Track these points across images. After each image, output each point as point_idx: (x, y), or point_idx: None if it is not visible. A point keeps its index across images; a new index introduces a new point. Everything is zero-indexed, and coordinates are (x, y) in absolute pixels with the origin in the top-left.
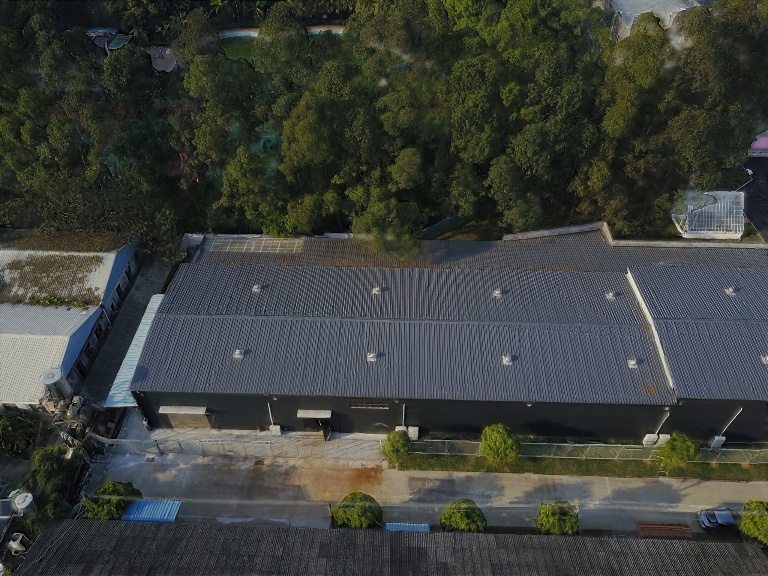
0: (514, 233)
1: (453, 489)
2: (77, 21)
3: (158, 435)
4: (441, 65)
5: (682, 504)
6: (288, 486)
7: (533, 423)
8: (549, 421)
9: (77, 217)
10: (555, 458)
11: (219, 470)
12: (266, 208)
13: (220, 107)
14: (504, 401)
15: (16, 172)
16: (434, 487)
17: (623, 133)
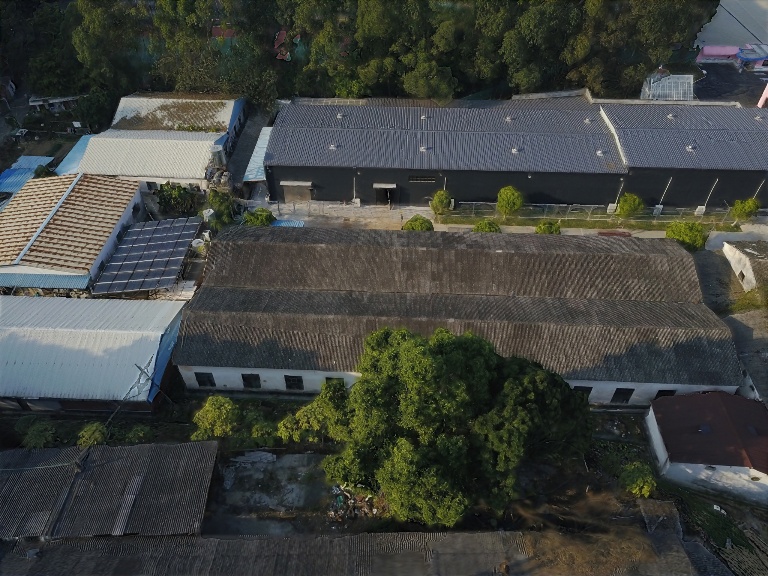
0: (520, 94)
1: None
2: None
3: (276, 206)
4: None
5: None
6: None
7: (532, 195)
8: (543, 193)
9: None
10: (547, 219)
11: (320, 223)
12: (343, 68)
13: None
14: (513, 171)
15: (166, 40)
16: None
17: (600, 17)
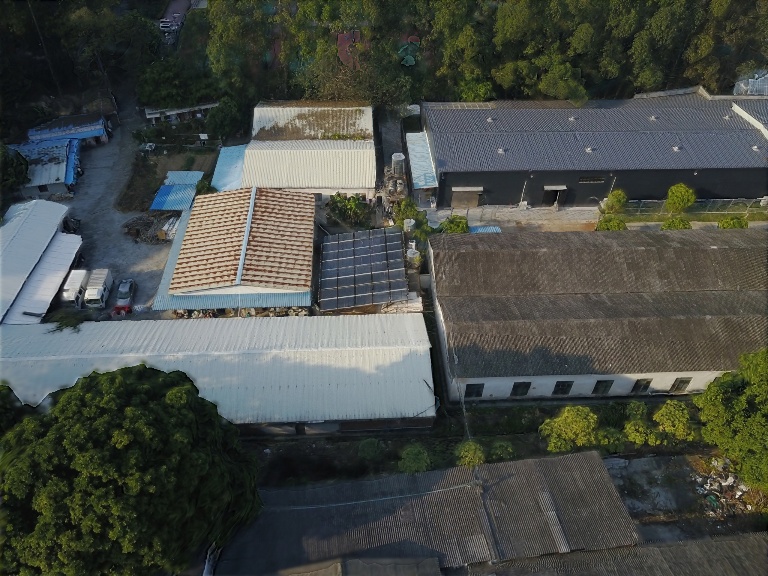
0: (642, 93)
1: None
2: None
3: (443, 213)
4: None
5: None
6: None
7: None
8: (704, 188)
9: None
10: (708, 213)
11: None
12: (479, 72)
13: None
14: (682, 169)
15: (302, 47)
16: (638, 229)
17: (718, 17)
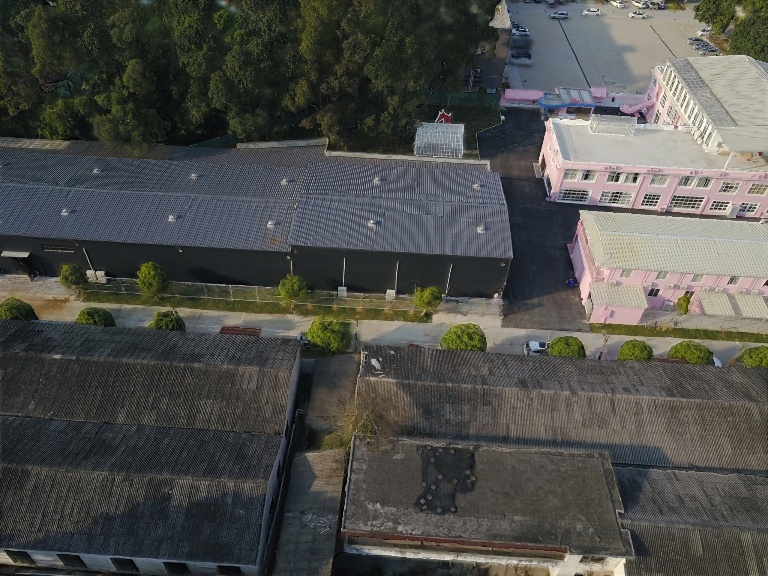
0: (246, 142)
1: (117, 315)
2: None
3: None
4: None
5: (293, 331)
6: None
7: (193, 270)
8: (205, 268)
9: None
10: (210, 299)
11: None
12: (26, 107)
13: None
14: (156, 244)
15: None
16: None
17: (329, 60)
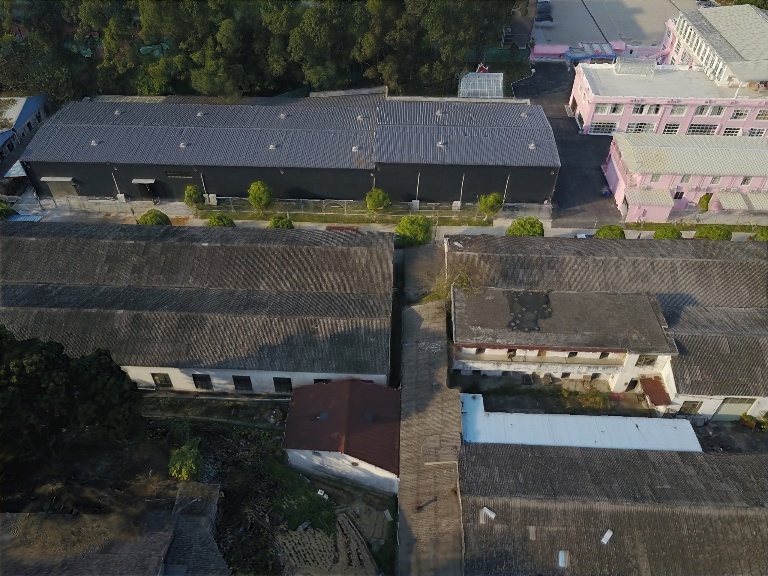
0: (317, 91)
1: None
2: None
3: (43, 202)
4: None
5: None
6: None
7: (291, 190)
8: (300, 188)
9: (0, 74)
10: (305, 214)
11: (80, 218)
12: (132, 66)
13: None
14: (263, 167)
15: None
16: None
17: (389, 16)
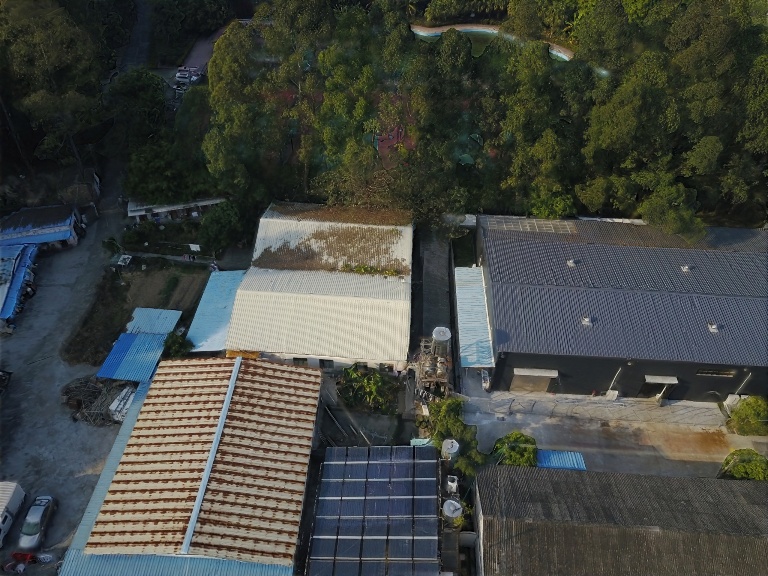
0: None
1: None
2: (242, 10)
3: (498, 397)
4: (739, 59)
5: None
6: (642, 446)
7: None
8: None
9: None
10: None
11: (571, 430)
12: (559, 189)
13: (535, 91)
14: None
15: (327, 146)
16: None
17: None
